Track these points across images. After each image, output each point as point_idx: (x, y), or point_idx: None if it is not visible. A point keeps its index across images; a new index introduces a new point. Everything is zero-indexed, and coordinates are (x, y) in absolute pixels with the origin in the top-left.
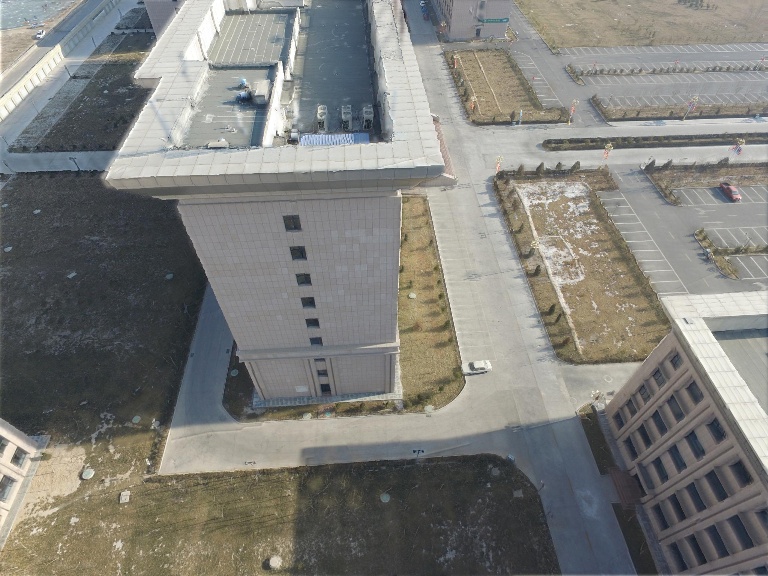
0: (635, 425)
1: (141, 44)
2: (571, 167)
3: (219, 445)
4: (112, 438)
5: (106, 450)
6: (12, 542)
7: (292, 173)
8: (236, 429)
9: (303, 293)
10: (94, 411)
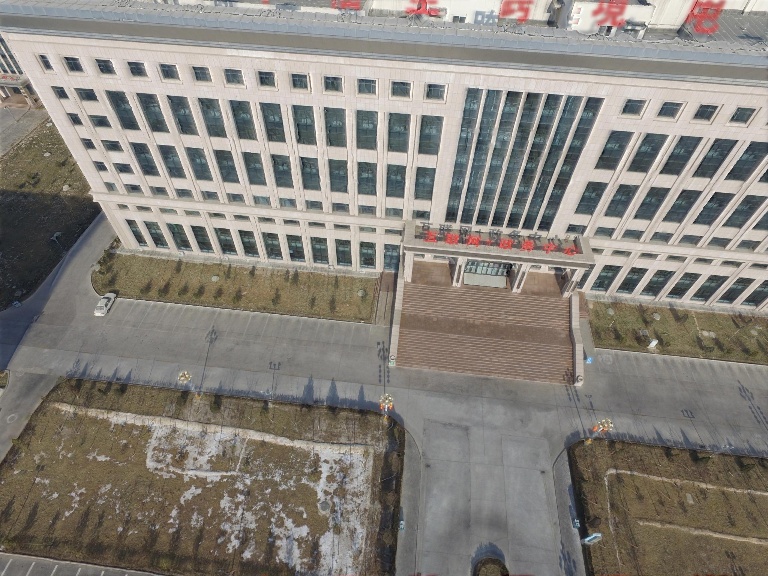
0: None
1: None
2: None
3: None
4: None
5: None
6: None
7: None
8: None
9: None
10: None
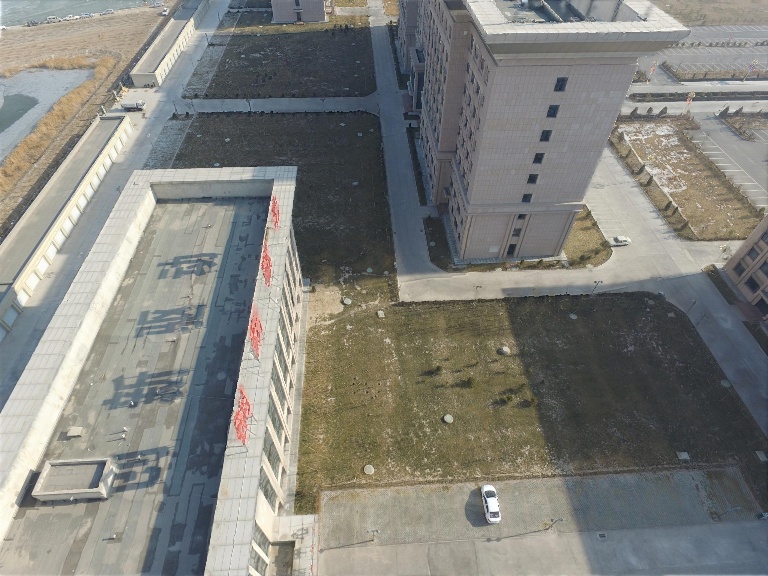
0: (758, 265)
1: (257, 20)
2: (659, 112)
3: (438, 286)
4: (356, 281)
5: (354, 288)
6: (310, 338)
7: (599, 33)
8: (447, 277)
9: (540, 149)
10: (335, 265)
